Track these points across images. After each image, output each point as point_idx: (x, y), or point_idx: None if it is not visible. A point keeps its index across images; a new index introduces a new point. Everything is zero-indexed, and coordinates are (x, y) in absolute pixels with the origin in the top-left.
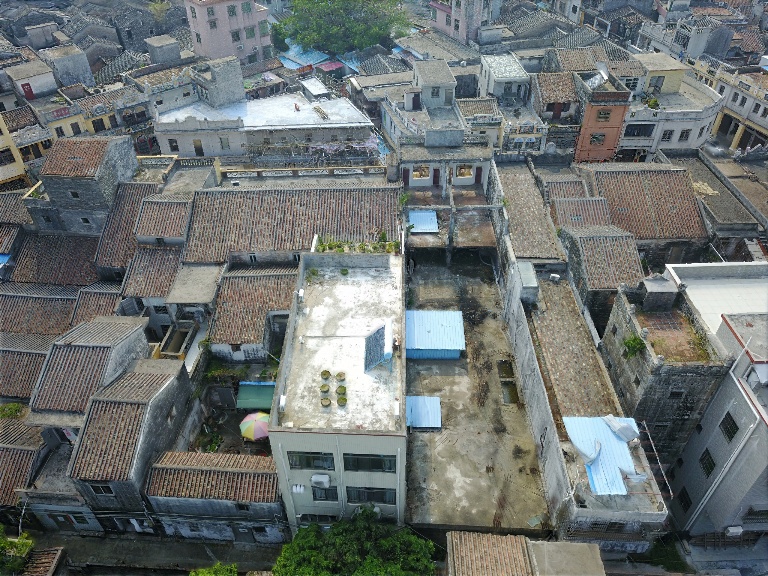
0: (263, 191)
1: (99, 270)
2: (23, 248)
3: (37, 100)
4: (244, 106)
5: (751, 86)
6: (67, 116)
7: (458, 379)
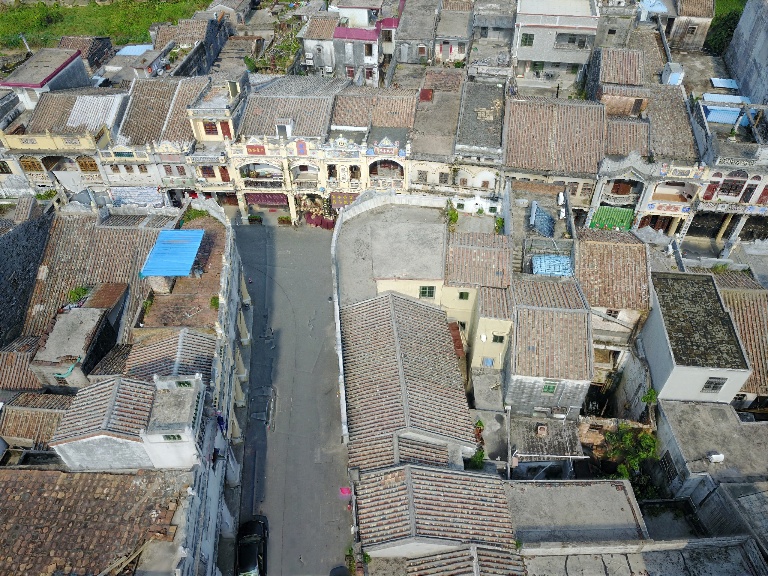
0: None
1: None
2: None
3: None
4: None
5: None
6: None
7: (702, 96)
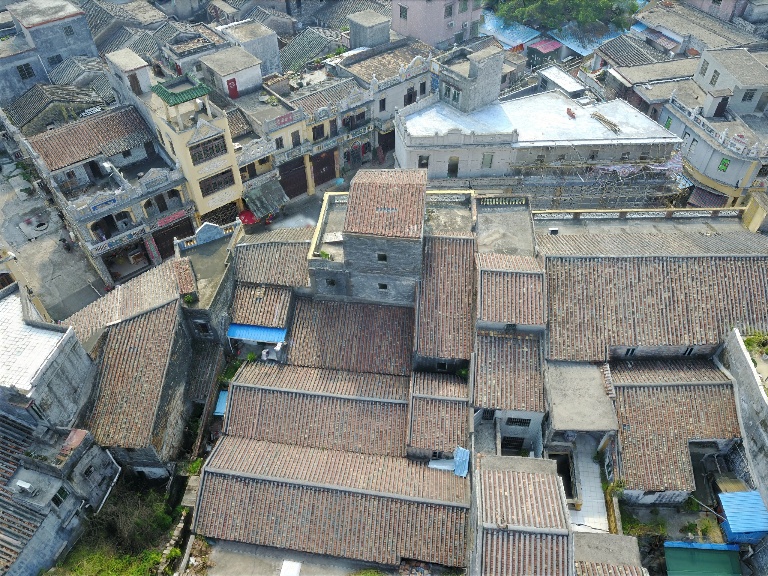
0: (638, 258)
1: (418, 360)
2: (296, 318)
3: (242, 99)
4: (500, 110)
5: None
6: (290, 123)
7: None
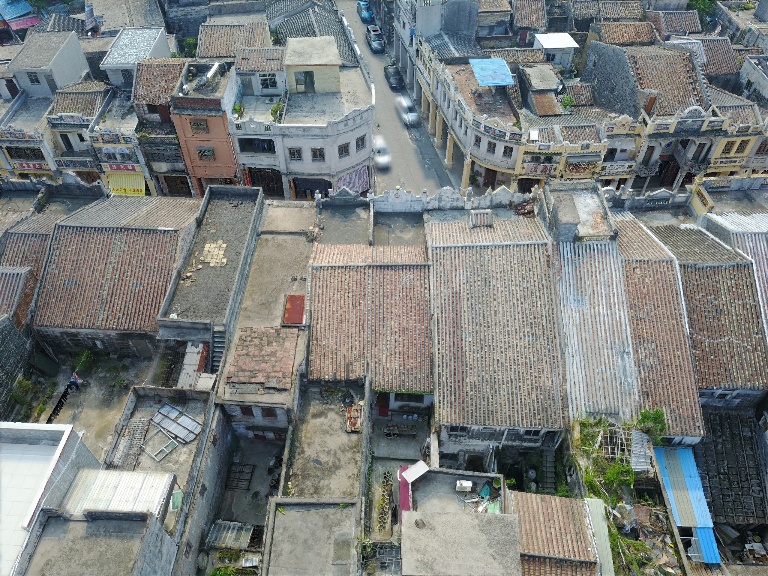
0: None
1: None
2: None
3: None
4: None
5: (450, 85)
6: None
7: None
